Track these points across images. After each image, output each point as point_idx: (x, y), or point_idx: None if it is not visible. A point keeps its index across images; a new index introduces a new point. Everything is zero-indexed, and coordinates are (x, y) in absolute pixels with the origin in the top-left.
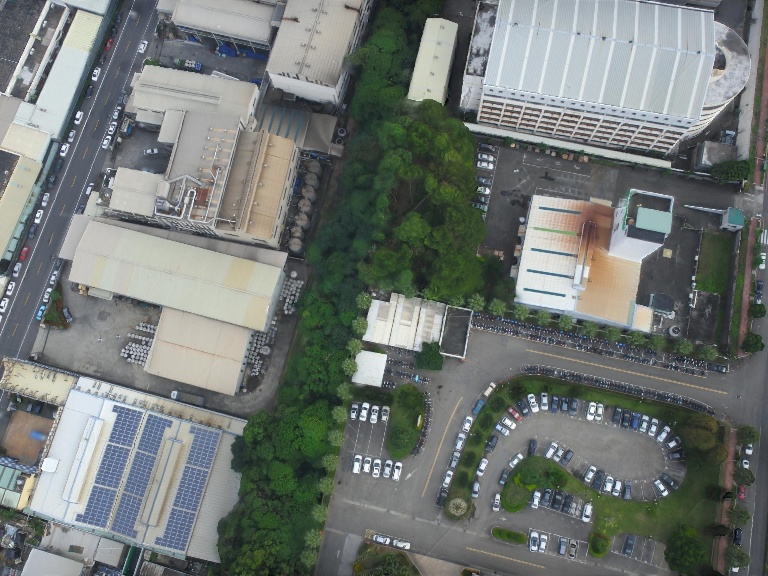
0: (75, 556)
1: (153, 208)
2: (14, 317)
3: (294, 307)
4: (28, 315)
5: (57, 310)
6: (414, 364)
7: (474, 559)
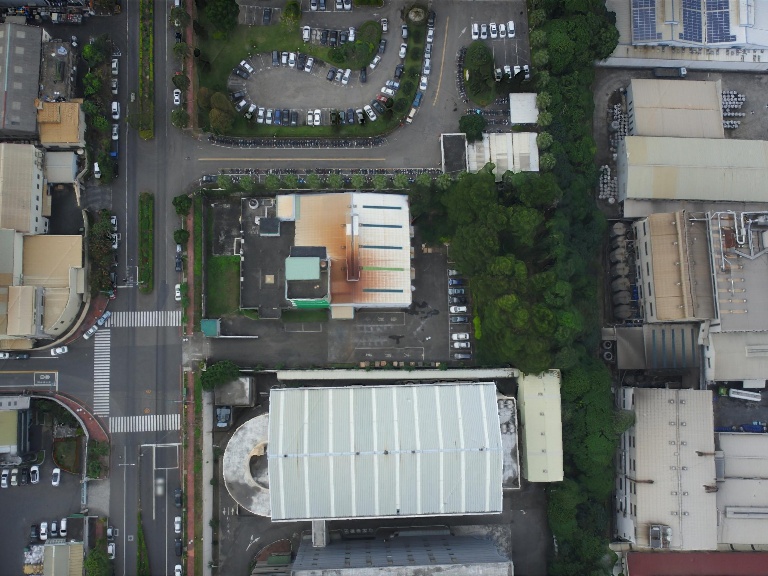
0: None
1: None
2: None
3: None
4: None
5: None
6: None
7: None
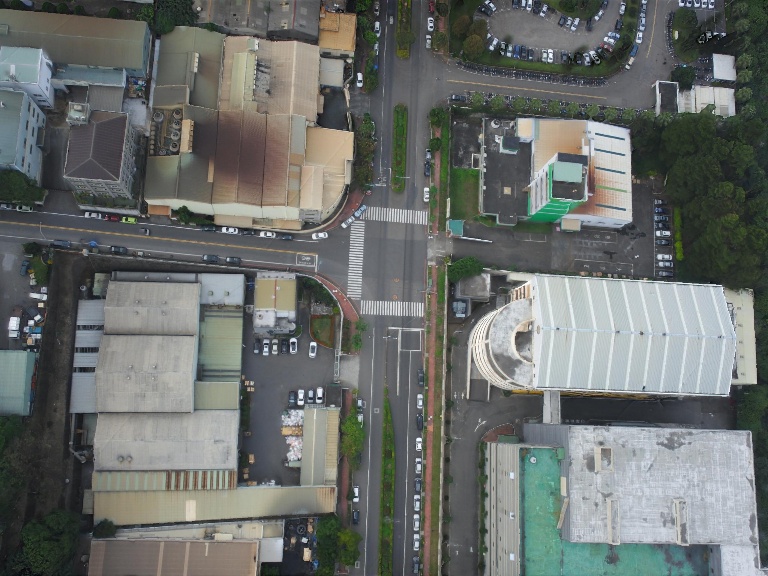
0: None
1: None
2: None
3: None
4: None
5: None
6: None
7: None
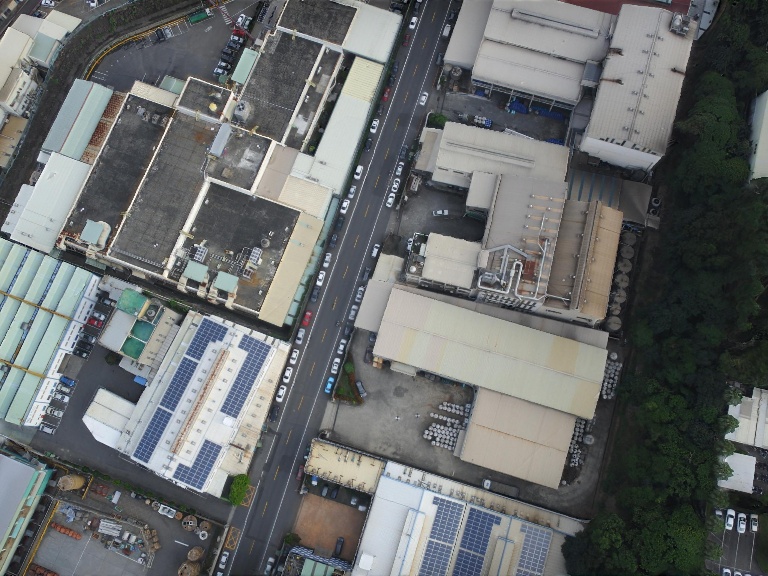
0: None
1: (471, 279)
2: (299, 388)
3: (614, 392)
4: (315, 387)
5: (349, 383)
6: None
7: None
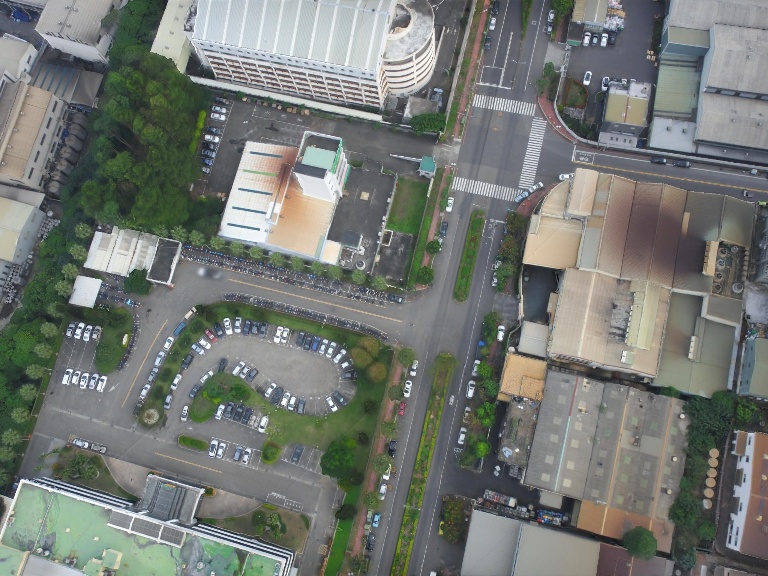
0: None
1: None
2: None
3: None
4: None
5: None
6: None
7: (160, 463)
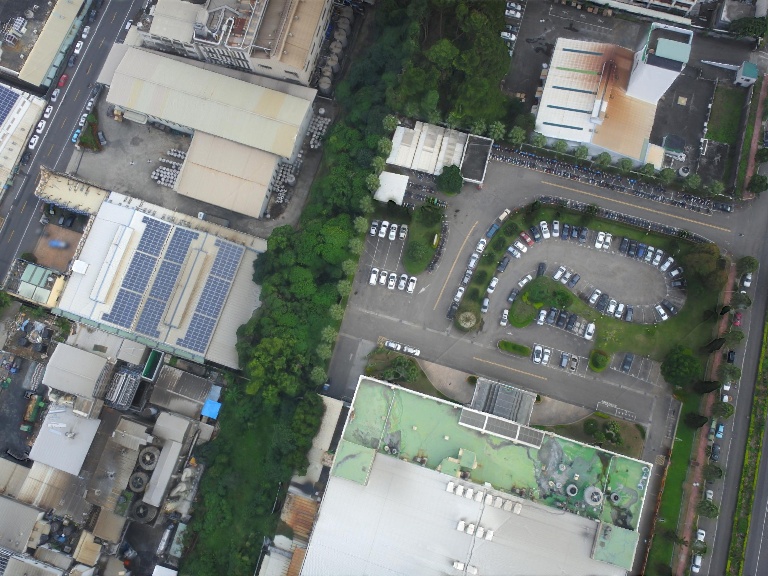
0: (99, 354)
1: (191, 35)
2: (50, 138)
3: (320, 142)
4: (64, 137)
5: (92, 133)
6: (434, 188)
7: (480, 368)
